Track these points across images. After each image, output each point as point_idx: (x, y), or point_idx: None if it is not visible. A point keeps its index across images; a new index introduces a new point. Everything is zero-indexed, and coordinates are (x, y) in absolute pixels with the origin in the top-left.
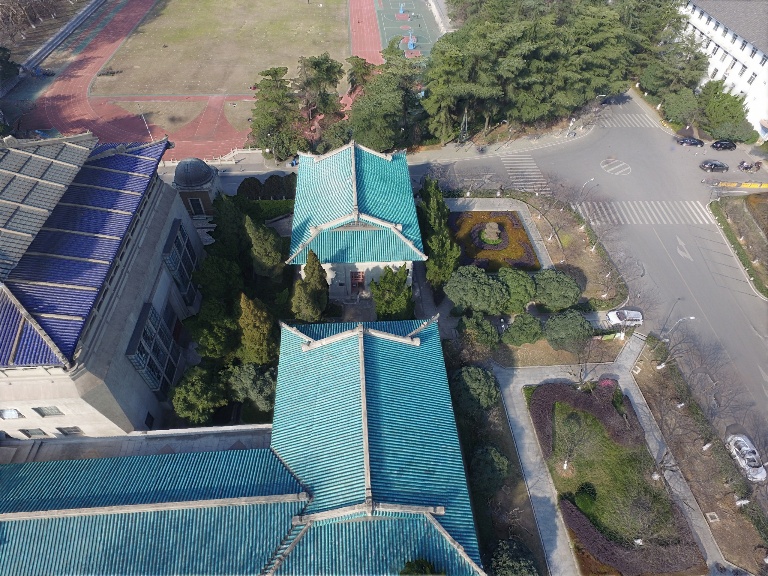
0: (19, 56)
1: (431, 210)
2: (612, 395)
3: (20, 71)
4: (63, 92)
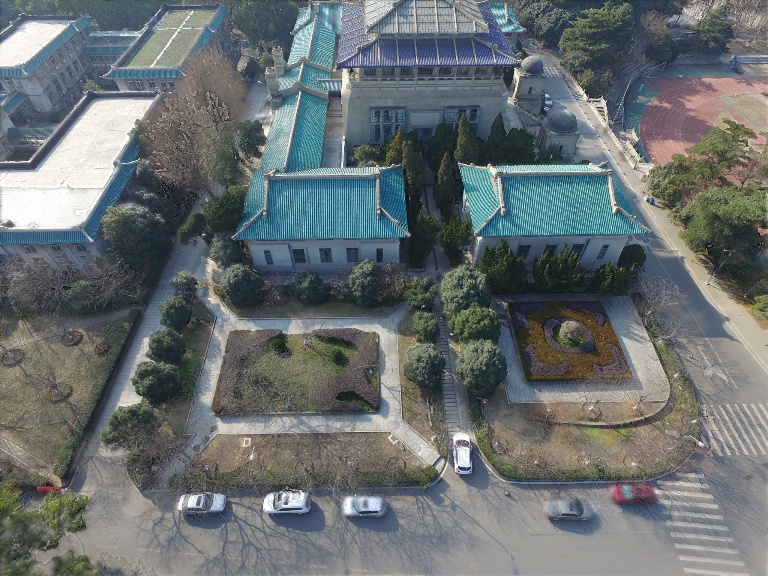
0: (754, 52)
1: (560, 255)
2: (360, 393)
3: (730, 59)
4: (717, 85)
